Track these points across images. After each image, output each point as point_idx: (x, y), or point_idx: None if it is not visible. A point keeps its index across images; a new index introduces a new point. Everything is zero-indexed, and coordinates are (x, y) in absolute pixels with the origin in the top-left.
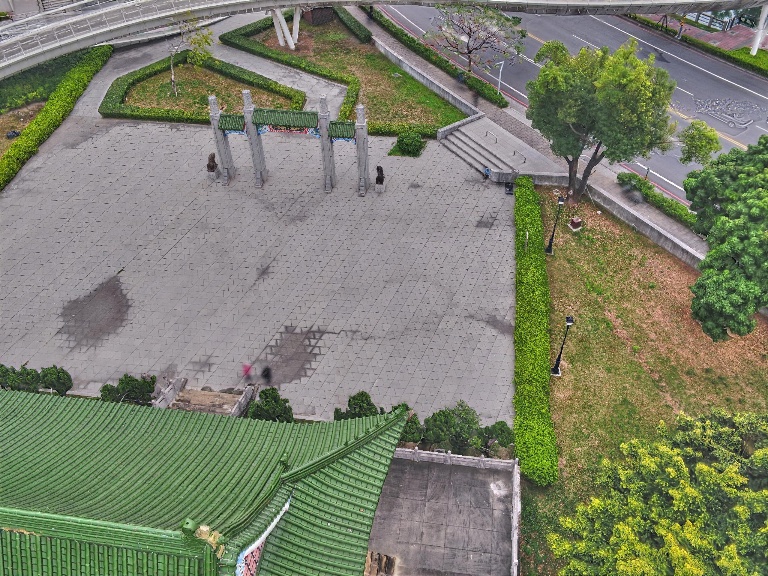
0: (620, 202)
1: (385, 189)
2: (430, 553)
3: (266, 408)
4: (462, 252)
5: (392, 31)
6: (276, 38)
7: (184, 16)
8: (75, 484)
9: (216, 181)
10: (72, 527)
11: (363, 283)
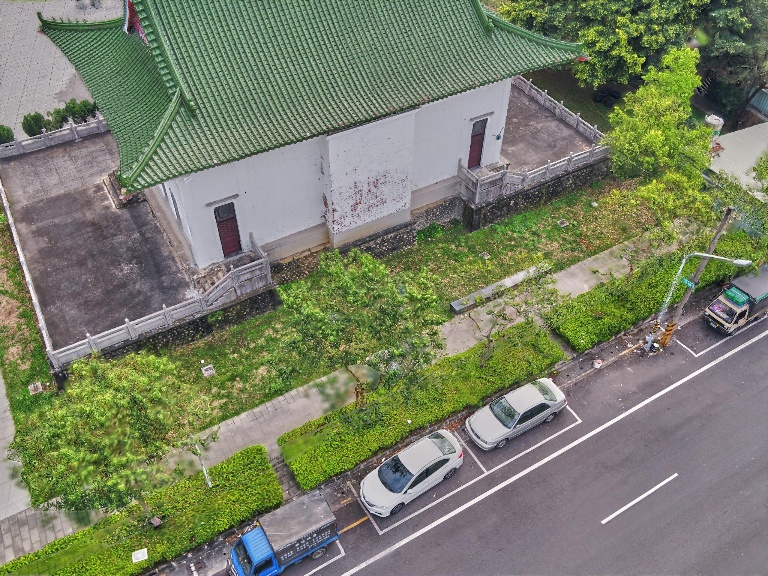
0: None
1: None
2: None
3: None
4: None
5: None
6: None
7: None
8: None
9: (87, 8)
10: None
11: None
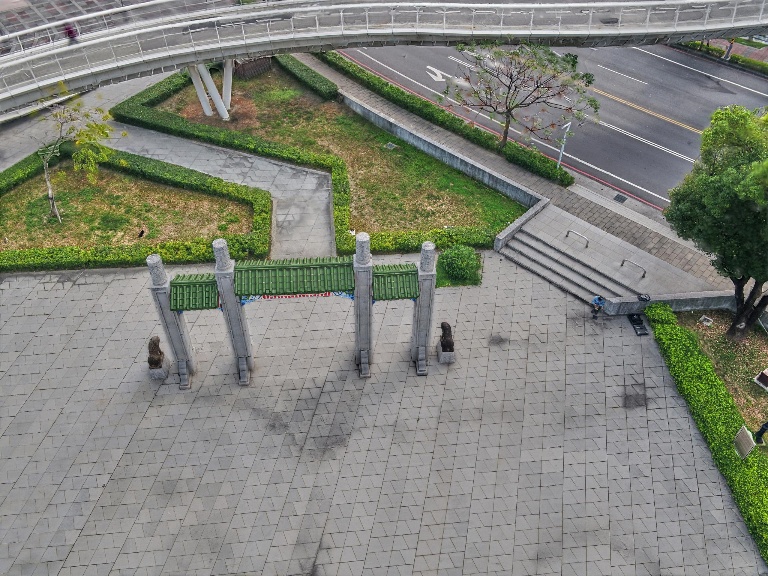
0: None
1: (454, 354)
2: None
3: None
4: (628, 466)
5: (364, 80)
6: (196, 104)
7: (53, 89)
8: None
9: (166, 382)
10: None
11: (497, 572)
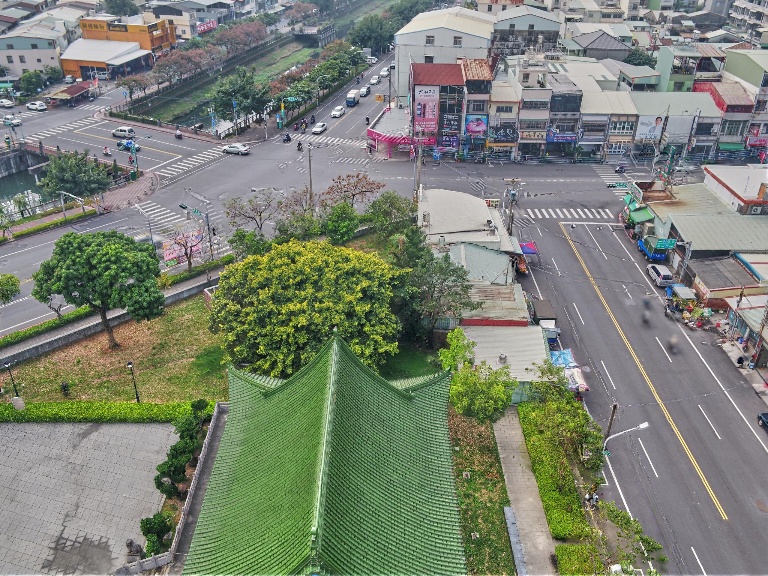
0: None
1: None
2: None
3: (162, 519)
4: None
5: None
6: None
7: None
8: (288, 445)
9: None
10: None
11: (7, 517)
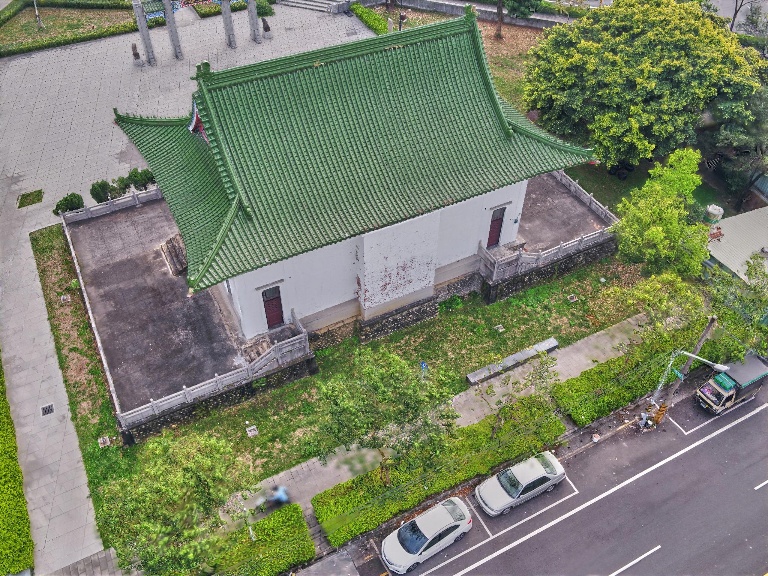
0: None
1: None
2: None
3: None
4: None
5: None
6: None
7: None
8: None
9: (144, 66)
10: (418, 33)
11: None
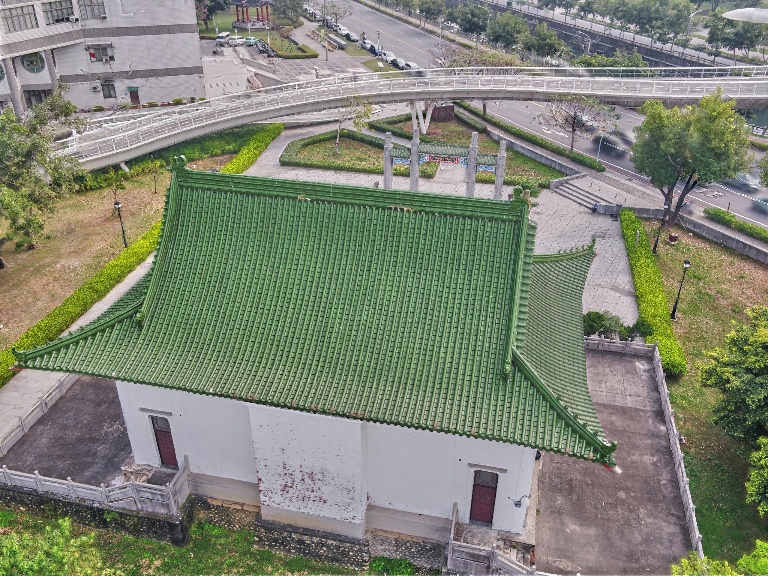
0: (708, 225)
1: None
2: (596, 394)
3: None
4: None
5: (503, 126)
6: (410, 127)
7: (347, 101)
8: None
9: None
10: (438, 201)
11: None
